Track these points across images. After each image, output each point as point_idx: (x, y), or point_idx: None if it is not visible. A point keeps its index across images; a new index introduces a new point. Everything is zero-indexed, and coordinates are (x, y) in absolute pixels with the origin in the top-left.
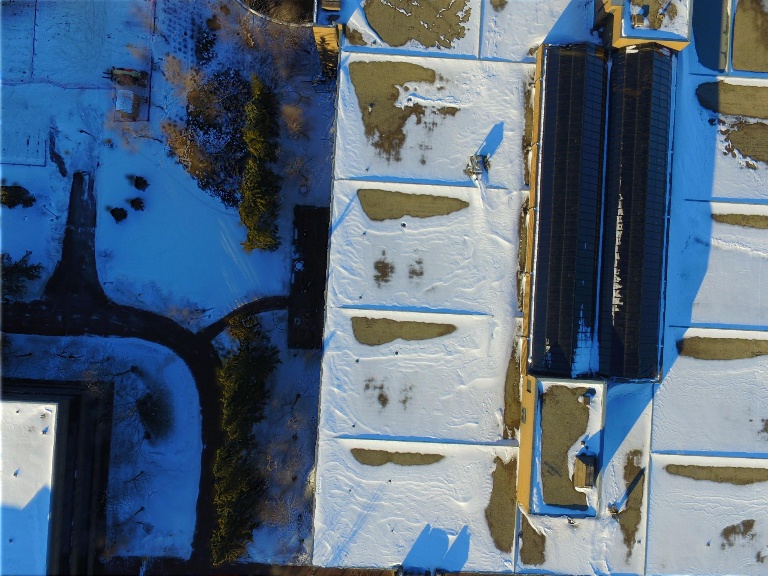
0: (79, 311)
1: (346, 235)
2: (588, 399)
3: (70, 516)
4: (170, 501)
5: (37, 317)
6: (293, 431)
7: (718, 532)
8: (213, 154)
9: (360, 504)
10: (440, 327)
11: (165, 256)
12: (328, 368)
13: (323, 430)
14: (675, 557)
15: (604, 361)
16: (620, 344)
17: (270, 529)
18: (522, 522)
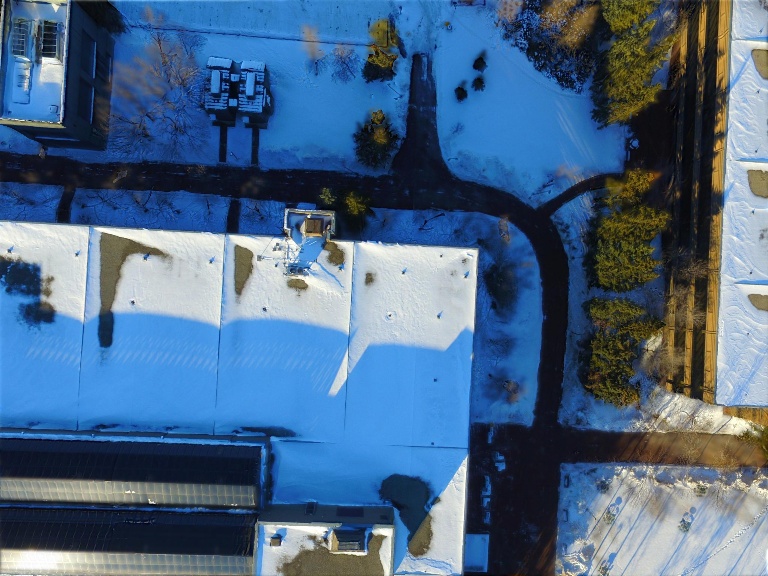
0: (425, 186)
1: (742, 92)
2: None
3: None
4: (515, 369)
5: (386, 191)
6: None
7: None
8: (550, 37)
9: (757, 347)
10: None
11: (506, 134)
12: (728, 217)
13: (725, 276)
14: None
15: None
16: None
17: None
18: None
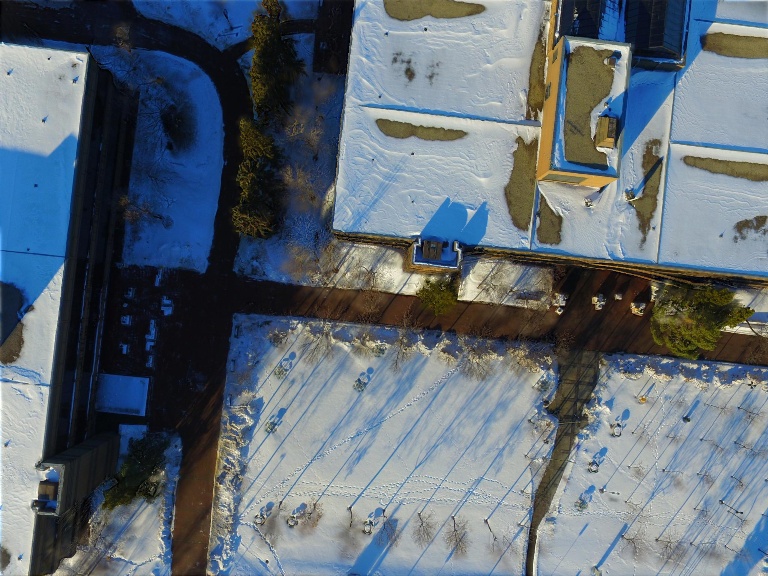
0: (108, 21)
1: None
2: (614, 60)
3: (93, 186)
4: (189, 213)
5: (66, 24)
6: (314, 149)
7: (731, 225)
8: None
9: (382, 174)
10: (469, 6)
11: None
12: (358, 37)
13: (350, 97)
14: (688, 245)
15: (630, 36)
16: (647, 15)
17: (286, 248)
18: (540, 202)
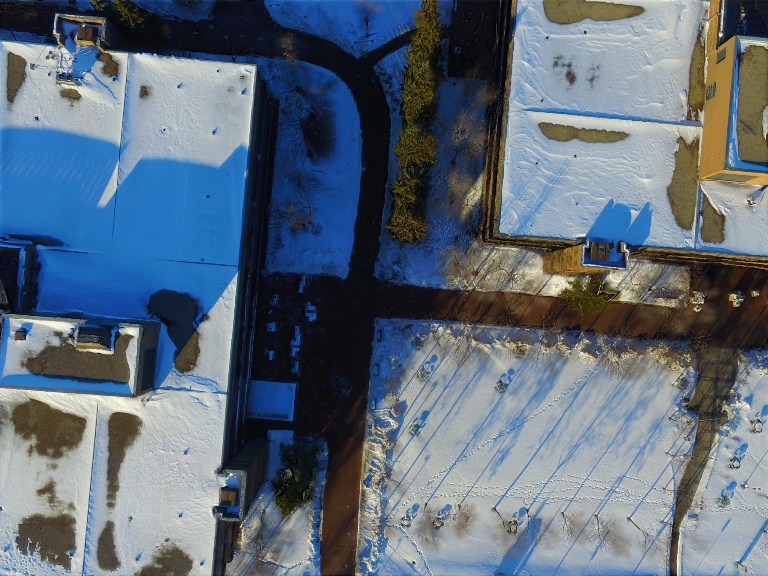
0: (245, 31)
1: None
2: None
3: (254, 195)
4: (330, 219)
5: (204, 35)
6: (453, 153)
7: None
8: None
9: (546, 177)
10: (628, 8)
11: None
12: (519, 42)
13: (513, 102)
14: None
15: None
16: None
17: (426, 252)
18: (702, 202)
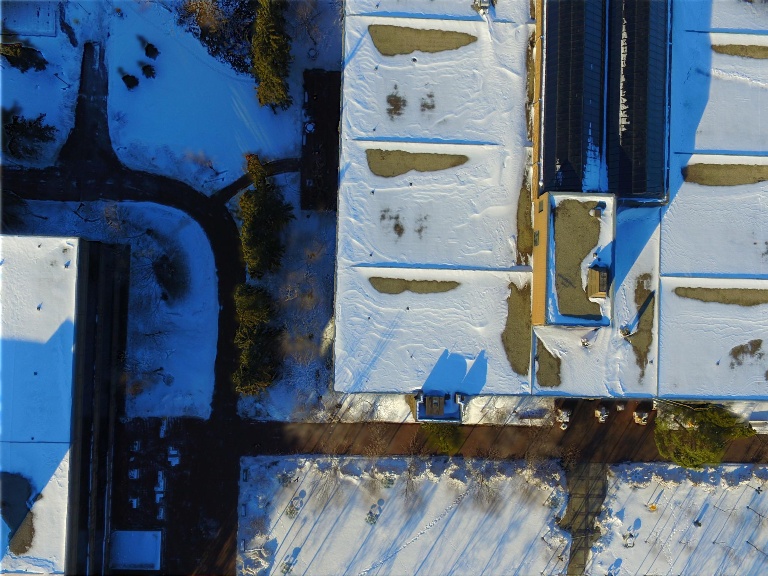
0: (93, 177)
1: (359, 69)
2: (599, 211)
3: (92, 359)
4: (189, 361)
5: (52, 183)
6: (308, 288)
7: (727, 352)
8: (222, 21)
9: (379, 331)
10: (452, 158)
11: (177, 121)
12: (344, 198)
13: (341, 259)
14: (686, 376)
15: (613, 181)
16: (628, 161)
17: (288, 387)
18: (537, 346)
